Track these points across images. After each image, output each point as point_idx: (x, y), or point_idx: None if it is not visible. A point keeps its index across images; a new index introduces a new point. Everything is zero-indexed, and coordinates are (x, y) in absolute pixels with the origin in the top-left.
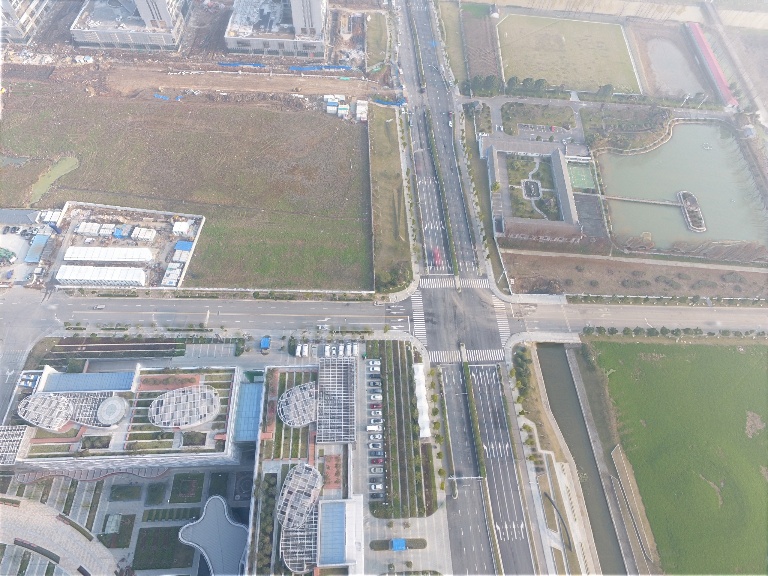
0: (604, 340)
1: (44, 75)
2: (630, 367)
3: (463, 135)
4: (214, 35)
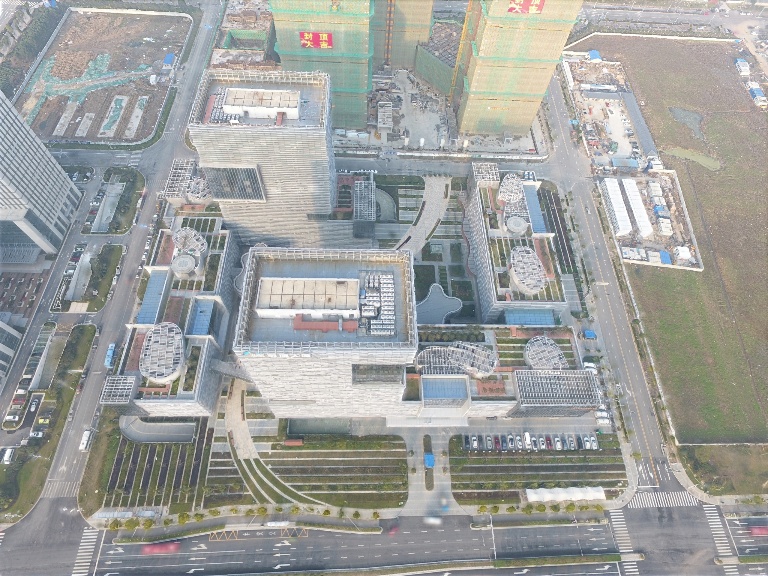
0: None
1: None
2: None
3: None
4: None
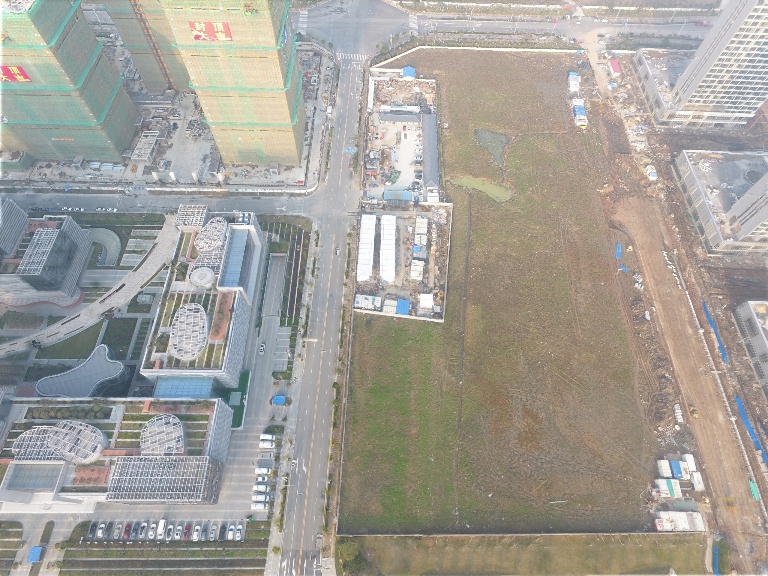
0: None
1: (618, 149)
2: None
3: None
4: (762, 290)
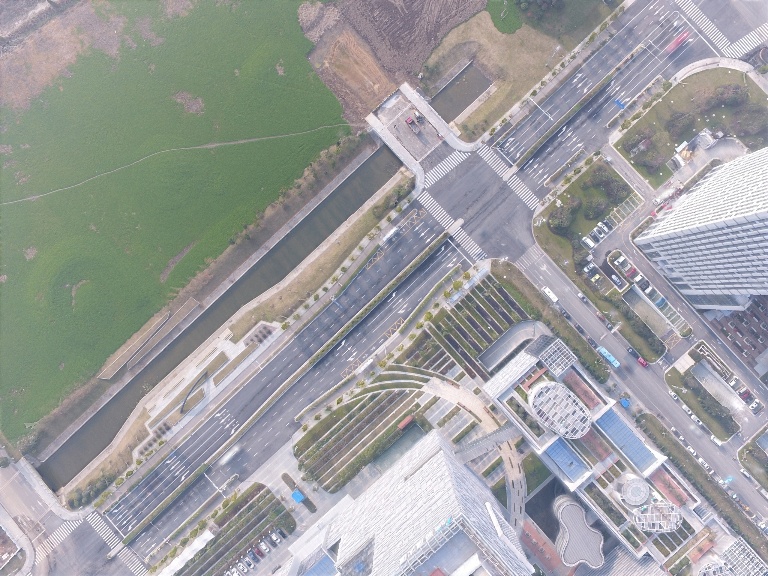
0: (4, 438)
1: None
2: (15, 402)
3: None
4: None
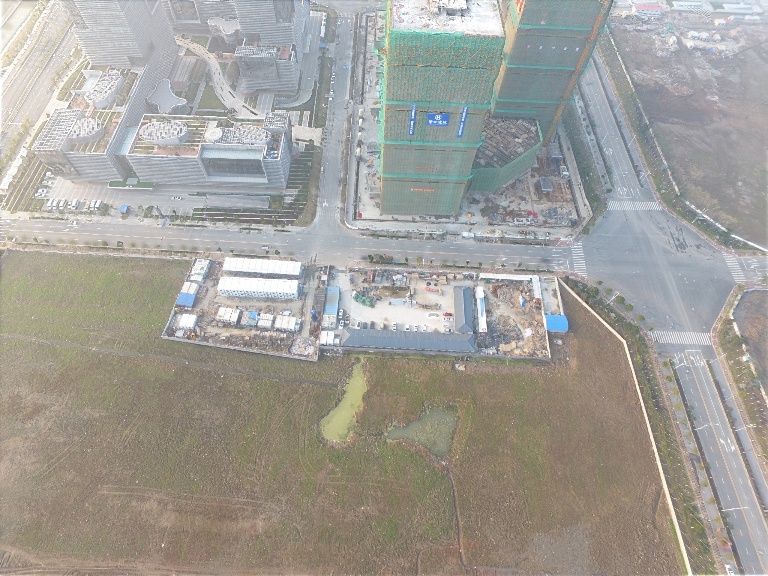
0: None
1: None
2: None
3: None
4: None
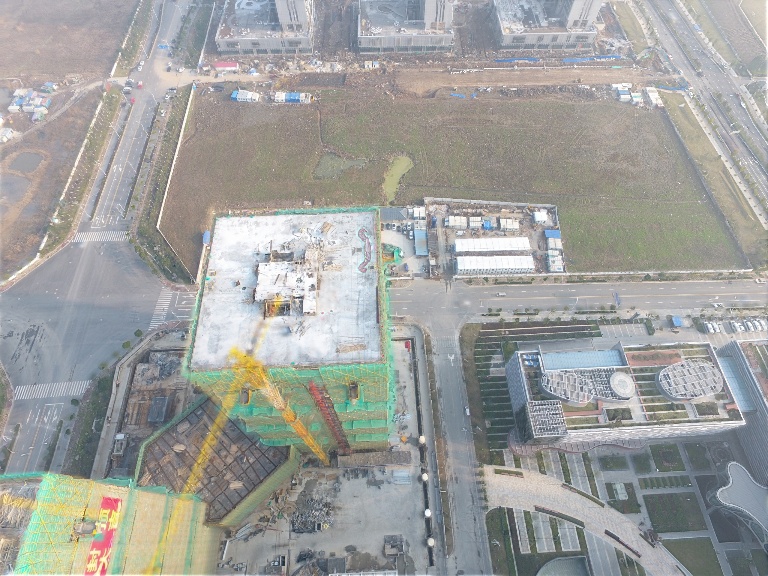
0: None
1: (338, 82)
2: None
3: (761, 115)
4: (476, 34)
